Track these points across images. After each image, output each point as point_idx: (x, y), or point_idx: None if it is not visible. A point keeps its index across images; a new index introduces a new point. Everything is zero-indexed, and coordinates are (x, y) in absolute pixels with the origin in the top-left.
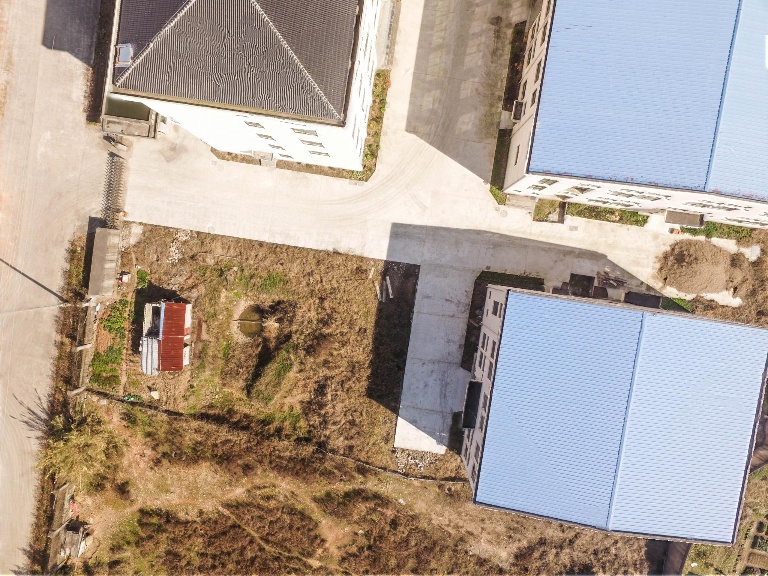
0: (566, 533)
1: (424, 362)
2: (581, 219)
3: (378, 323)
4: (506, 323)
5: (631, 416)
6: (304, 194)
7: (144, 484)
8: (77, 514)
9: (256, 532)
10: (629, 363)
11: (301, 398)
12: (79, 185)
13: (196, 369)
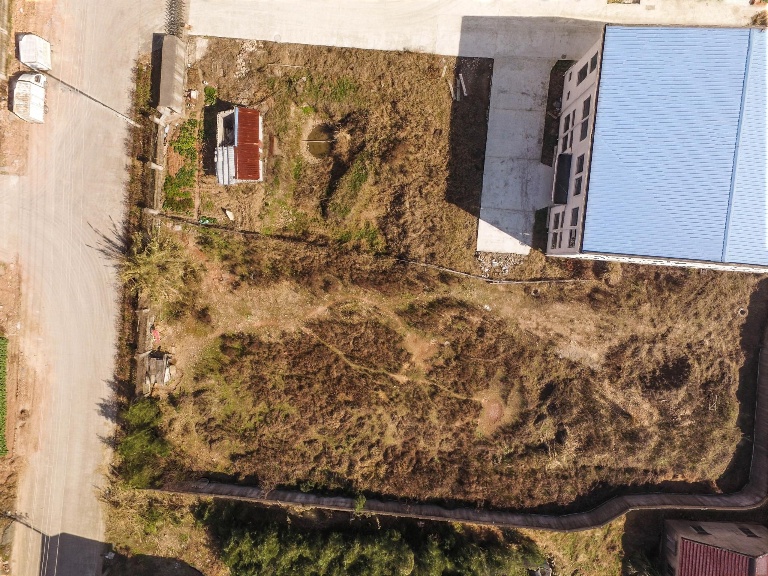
0: (658, 328)
1: (503, 160)
2: None
3: (453, 123)
4: (605, 60)
5: (742, 141)
6: None
7: (224, 308)
8: (159, 343)
9: (341, 349)
10: (738, 85)
11: (376, 214)
12: (141, 1)
13: (270, 186)
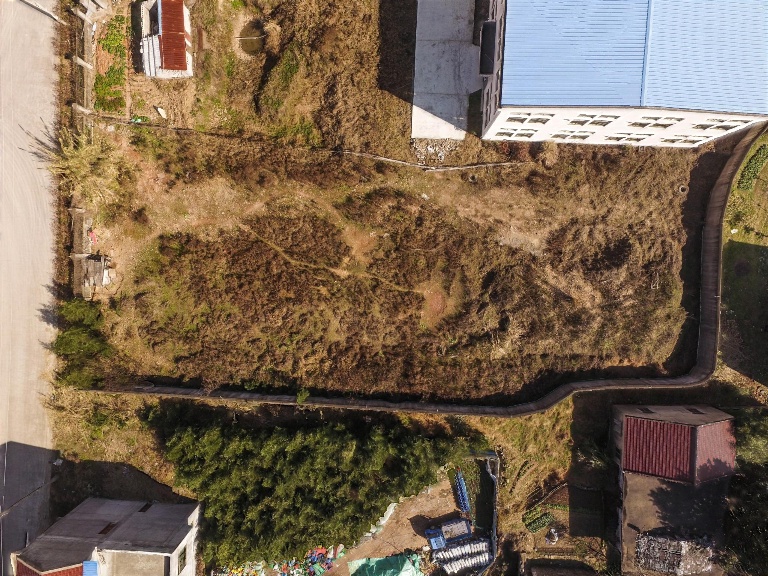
0: (598, 209)
1: (434, 43)
2: None
3: (382, 7)
4: None
5: None
6: None
7: (161, 208)
8: (97, 246)
9: (279, 245)
10: None
11: (311, 109)
12: None
13: (201, 81)
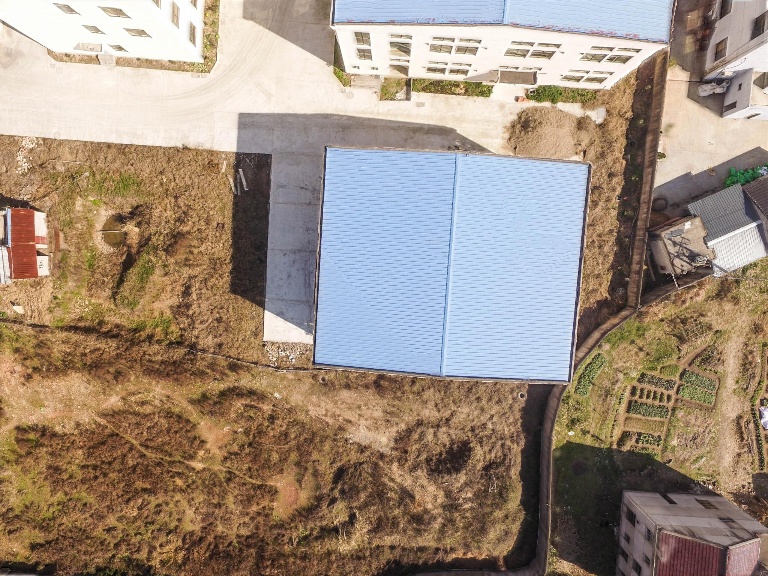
0: (442, 412)
1: (285, 253)
2: (427, 94)
3: (235, 217)
4: (327, 180)
5: (454, 260)
6: (147, 91)
7: (17, 401)
8: None
9: (134, 439)
10: (447, 207)
11: (171, 303)
12: None
13: (57, 280)
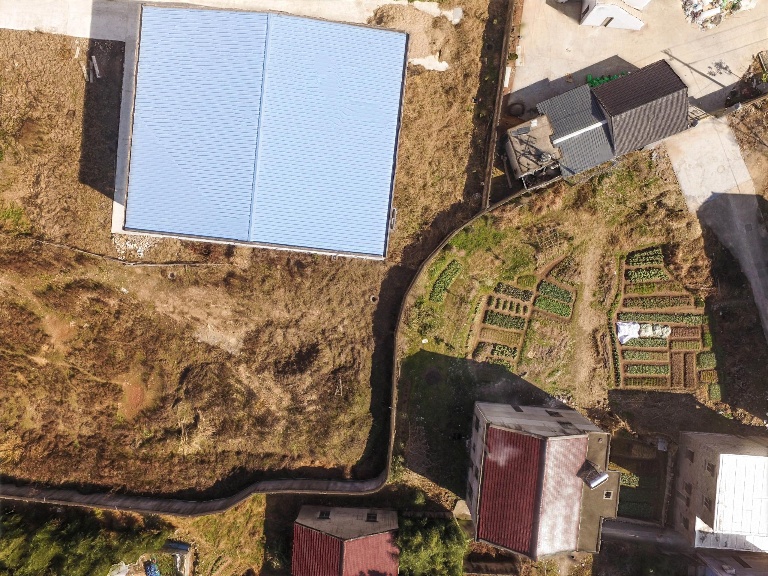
0: (292, 313)
1: None
2: None
3: (87, 104)
4: (142, 39)
5: (264, 122)
6: None
7: None
8: None
9: None
10: (258, 67)
11: (23, 194)
12: None
13: None
